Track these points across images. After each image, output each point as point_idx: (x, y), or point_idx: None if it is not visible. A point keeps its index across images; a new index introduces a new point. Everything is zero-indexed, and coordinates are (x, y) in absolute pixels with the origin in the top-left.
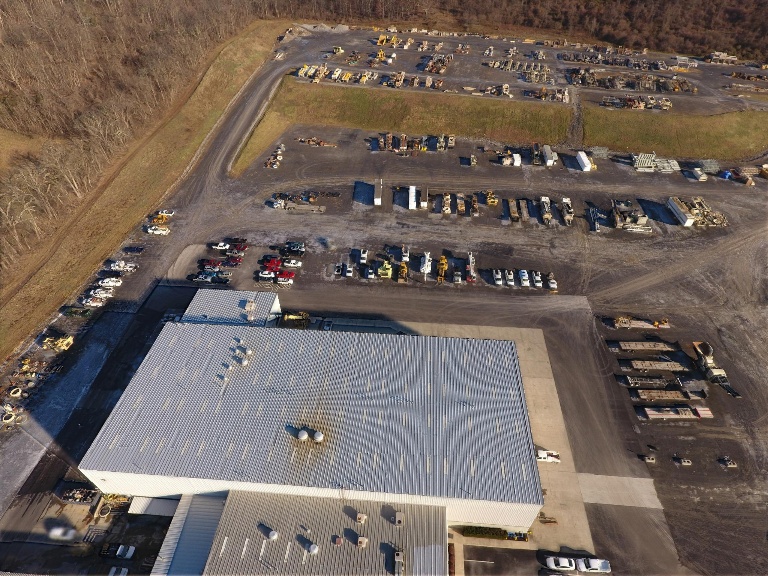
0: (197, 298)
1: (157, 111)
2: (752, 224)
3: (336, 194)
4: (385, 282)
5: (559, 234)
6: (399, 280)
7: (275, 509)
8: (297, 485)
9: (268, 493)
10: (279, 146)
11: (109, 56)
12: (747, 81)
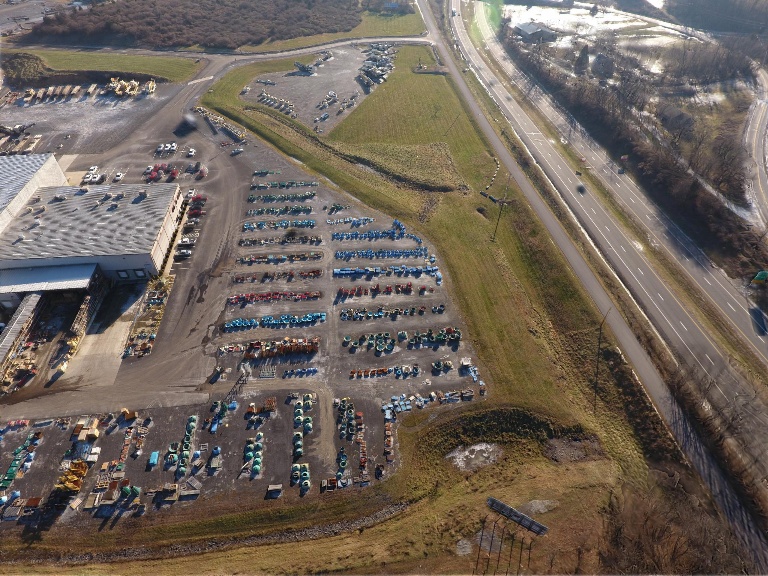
0: None
1: None
2: None
3: None
4: None
5: None
6: None
7: (5, 240)
8: None
9: None
10: None
11: None
12: None
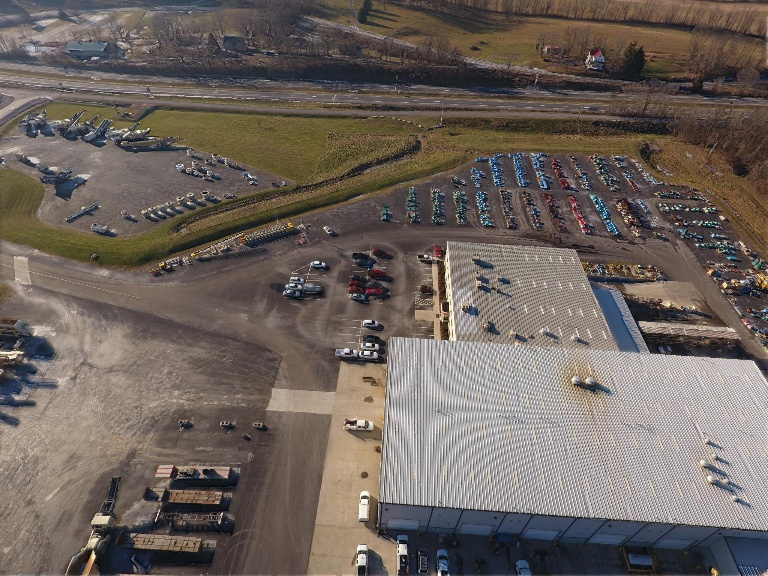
0: None
1: None
2: None
3: None
4: None
5: None
6: None
7: None
8: (575, 349)
9: None
10: None
11: None
12: None
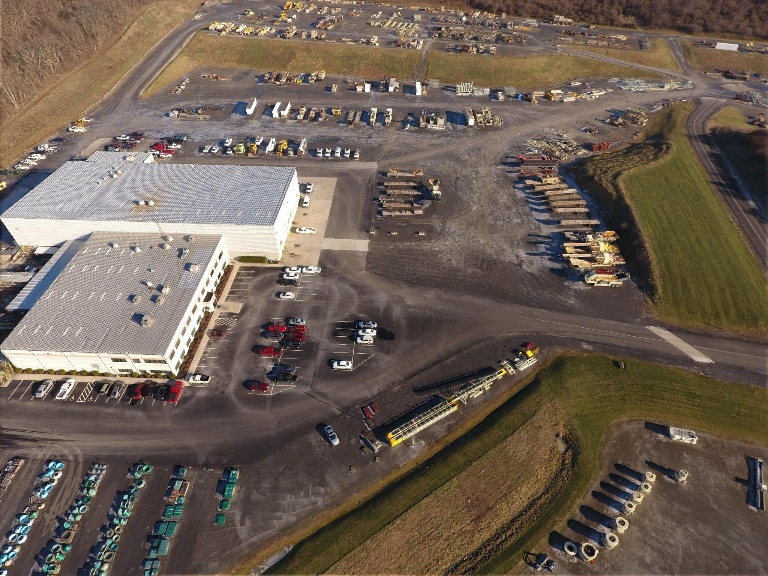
0: (94, 155)
1: (86, 53)
2: (519, 124)
3: (220, 109)
4: (239, 156)
5: (378, 131)
6: (249, 155)
7: (120, 238)
8: (132, 221)
9: (117, 232)
10: (185, 80)
11: (46, 10)
12: (571, 36)
